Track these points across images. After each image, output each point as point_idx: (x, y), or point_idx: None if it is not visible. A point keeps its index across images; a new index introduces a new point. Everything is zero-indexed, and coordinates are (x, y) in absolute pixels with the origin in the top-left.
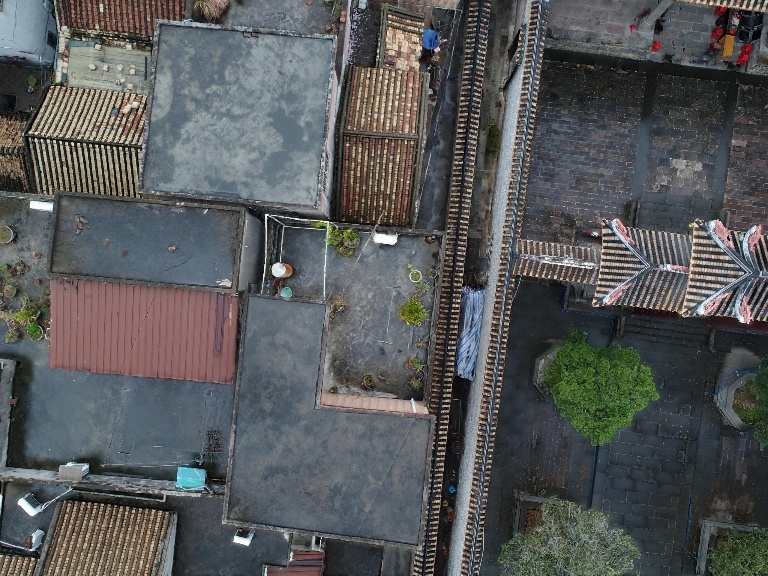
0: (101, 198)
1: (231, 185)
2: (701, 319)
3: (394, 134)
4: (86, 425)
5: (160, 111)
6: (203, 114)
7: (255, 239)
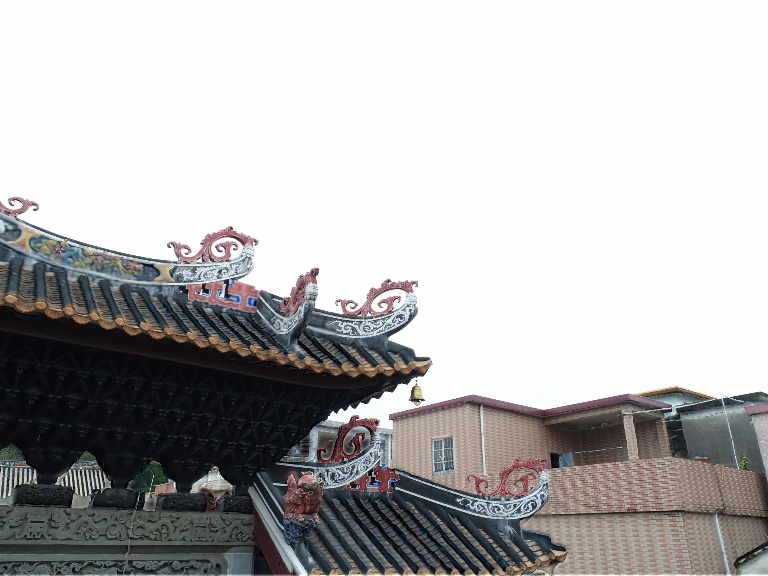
0: None
1: None
2: None
3: None
4: None
5: None
6: None
7: (751, 470)
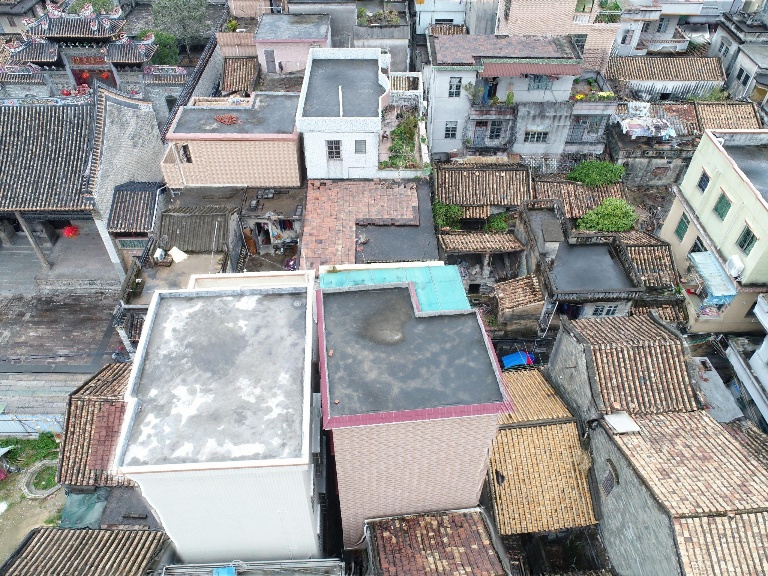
0: (339, 2)
1: (296, 16)
2: None
3: (236, 56)
4: (356, 4)
5: (324, 26)
6: (307, 26)
7: None
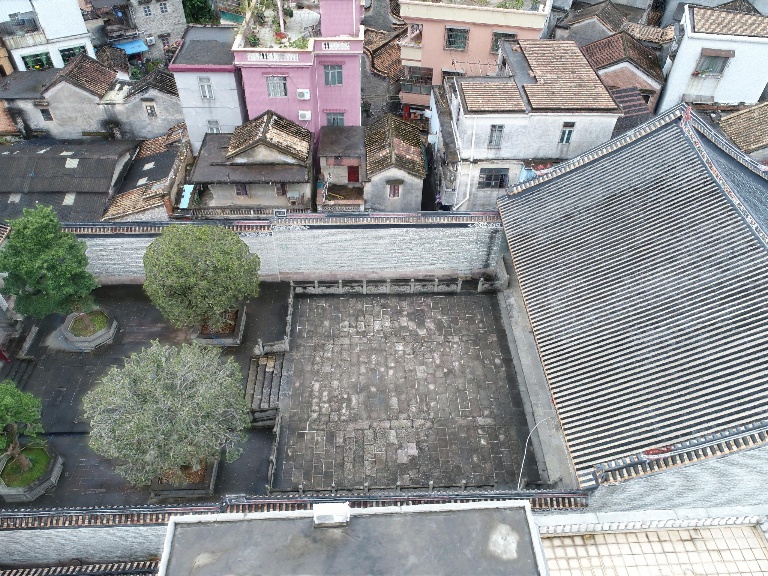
0: None
1: None
2: (3, 367)
3: None
4: None
5: None
6: None
7: None
